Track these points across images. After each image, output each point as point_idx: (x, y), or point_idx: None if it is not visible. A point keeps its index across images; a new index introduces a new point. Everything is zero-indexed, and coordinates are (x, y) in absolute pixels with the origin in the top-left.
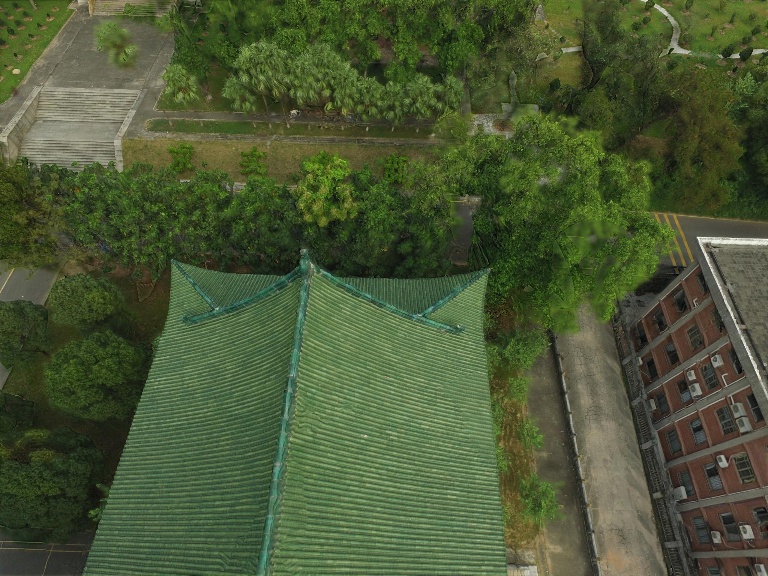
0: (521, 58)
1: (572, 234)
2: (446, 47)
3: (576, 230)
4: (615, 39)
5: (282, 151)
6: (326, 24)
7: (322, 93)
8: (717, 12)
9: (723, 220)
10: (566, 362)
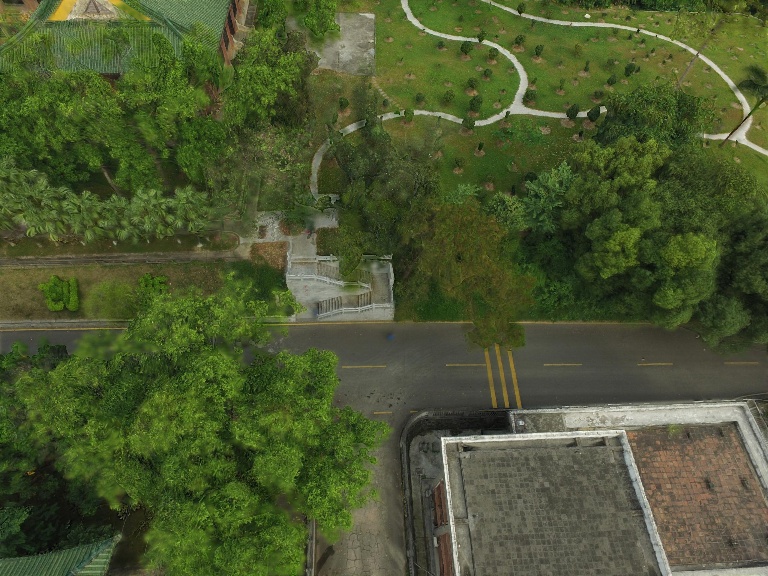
0: (263, 167)
1: (372, 363)
2: (180, 150)
3: (379, 356)
4: (373, 143)
5: (2, 279)
6: (6, 131)
7: (14, 219)
8: (573, 57)
9: (562, 324)
10: (336, 557)
